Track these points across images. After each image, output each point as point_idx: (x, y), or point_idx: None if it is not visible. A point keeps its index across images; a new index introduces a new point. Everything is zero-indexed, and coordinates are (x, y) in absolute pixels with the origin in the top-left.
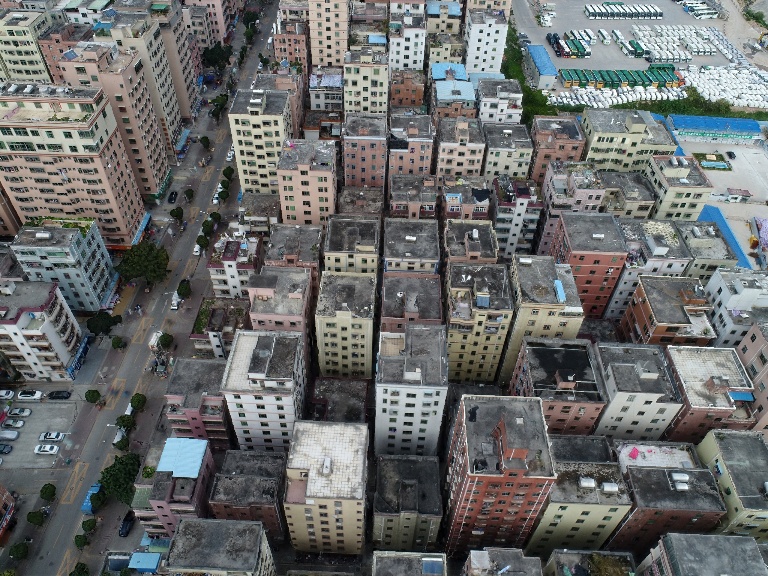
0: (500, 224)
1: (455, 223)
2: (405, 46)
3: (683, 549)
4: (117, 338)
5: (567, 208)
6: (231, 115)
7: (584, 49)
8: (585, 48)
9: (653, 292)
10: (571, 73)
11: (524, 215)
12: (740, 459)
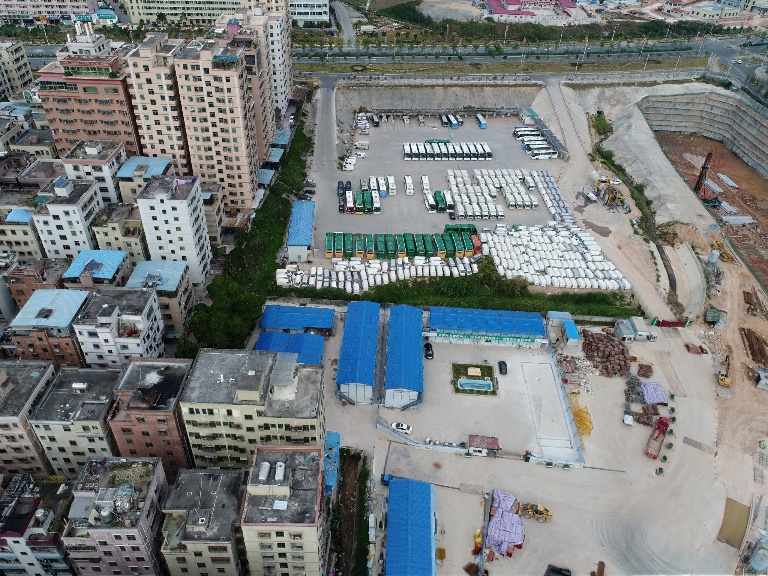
0: (3, 563)
1: None
2: (56, 225)
3: None
4: None
5: (91, 549)
6: None
7: (372, 203)
8: (373, 202)
9: None
10: (336, 239)
11: (33, 553)
12: None
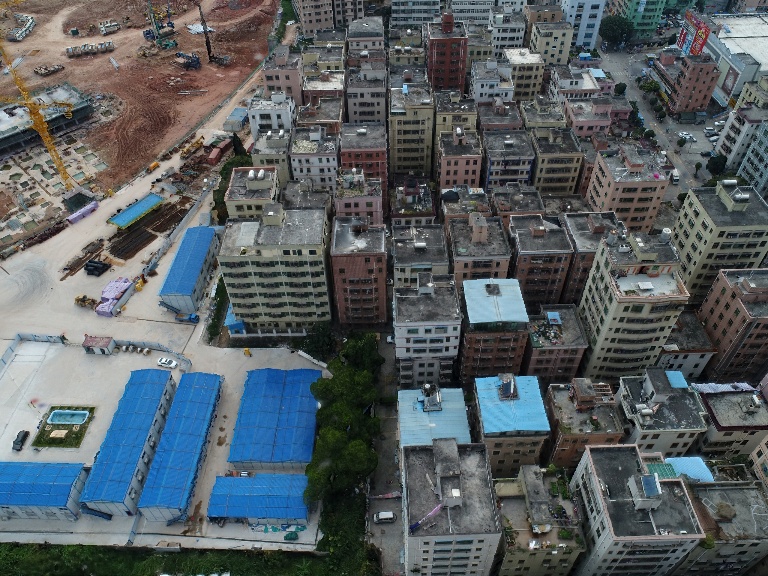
0: None
1: (474, 157)
2: None
3: (379, 29)
4: (699, 163)
5: None
6: (749, 187)
7: None
8: None
9: (333, 116)
10: None
11: None
12: (333, 58)
